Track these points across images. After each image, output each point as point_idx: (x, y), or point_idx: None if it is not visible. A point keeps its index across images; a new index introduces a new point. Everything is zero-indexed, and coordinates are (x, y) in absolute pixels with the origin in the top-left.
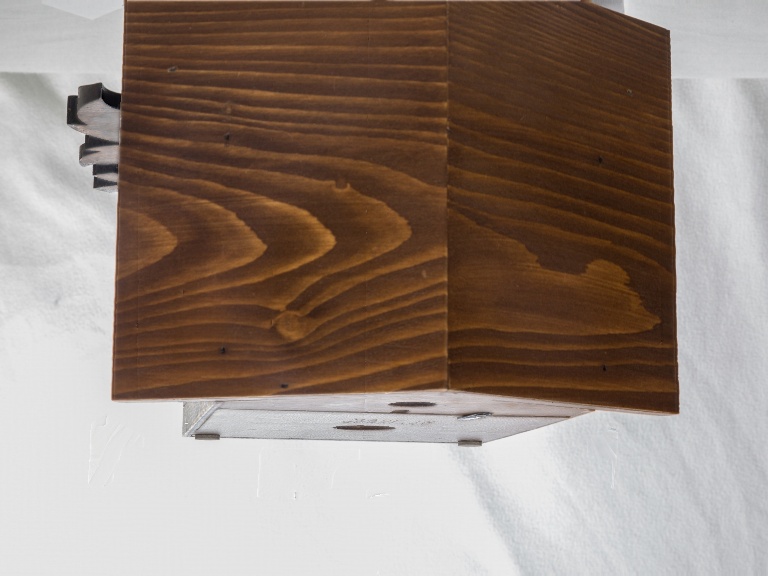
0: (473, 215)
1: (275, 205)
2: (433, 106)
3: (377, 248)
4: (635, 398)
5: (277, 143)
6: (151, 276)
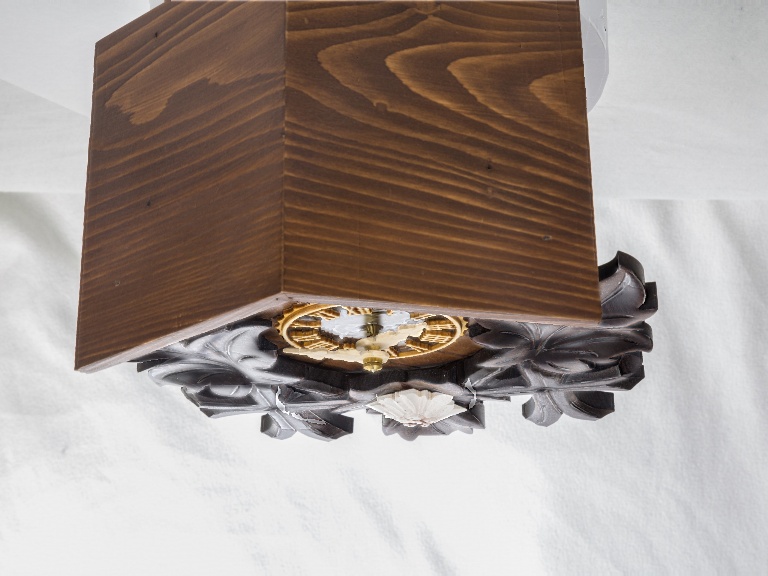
0: (263, 79)
1: (442, 101)
2: (297, 156)
3: (348, 49)
4: (132, 29)
5: (442, 152)
6: (551, 64)
